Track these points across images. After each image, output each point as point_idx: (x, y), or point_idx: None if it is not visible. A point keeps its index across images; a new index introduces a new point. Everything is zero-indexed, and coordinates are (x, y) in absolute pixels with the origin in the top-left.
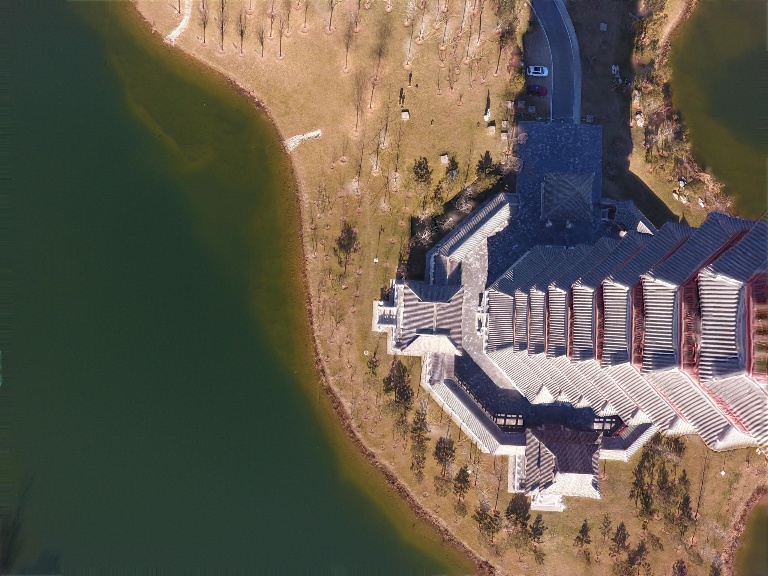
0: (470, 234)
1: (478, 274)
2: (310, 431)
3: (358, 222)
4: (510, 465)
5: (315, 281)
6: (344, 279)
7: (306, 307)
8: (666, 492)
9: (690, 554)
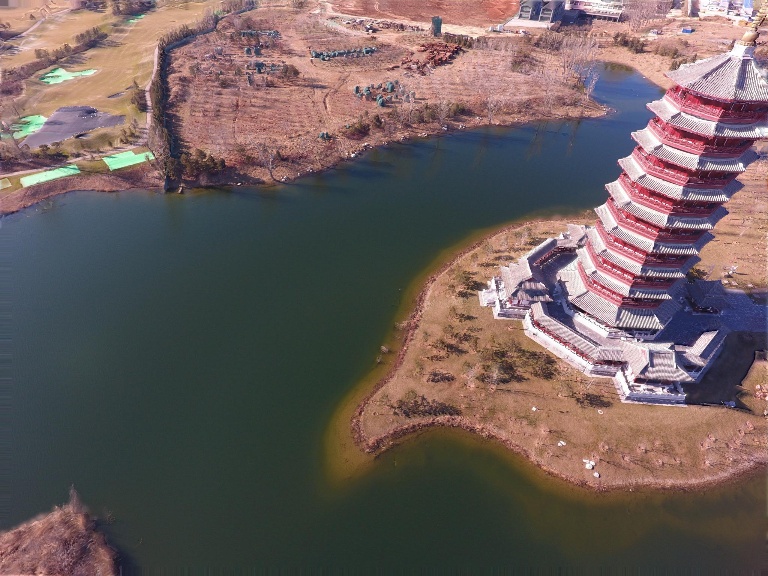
0: None
1: None
2: None
3: None
4: None
5: None
6: None
7: None
8: (508, 366)
9: None
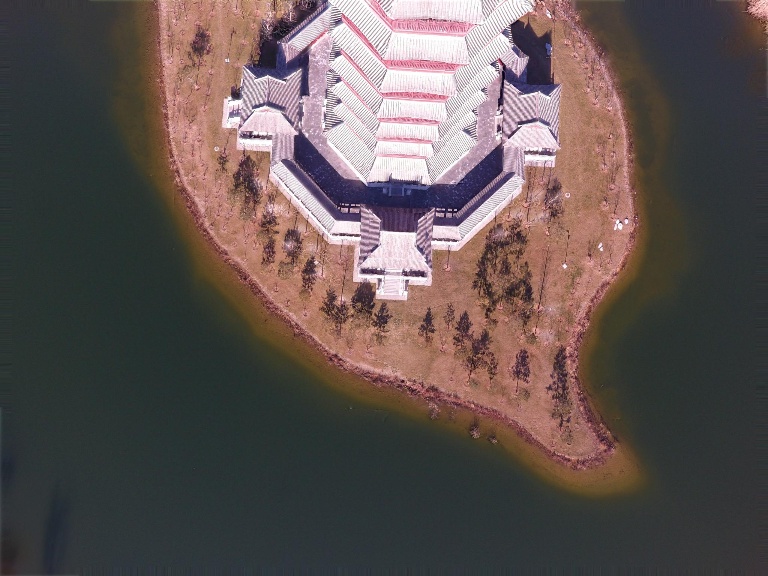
0: (310, 23)
1: (325, 71)
2: (166, 232)
3: (211, 25)
4: (356, 256)
5: (171, 85)
6: (189, 68)
7: (162, 111)
8: None
9: (528, 337)
